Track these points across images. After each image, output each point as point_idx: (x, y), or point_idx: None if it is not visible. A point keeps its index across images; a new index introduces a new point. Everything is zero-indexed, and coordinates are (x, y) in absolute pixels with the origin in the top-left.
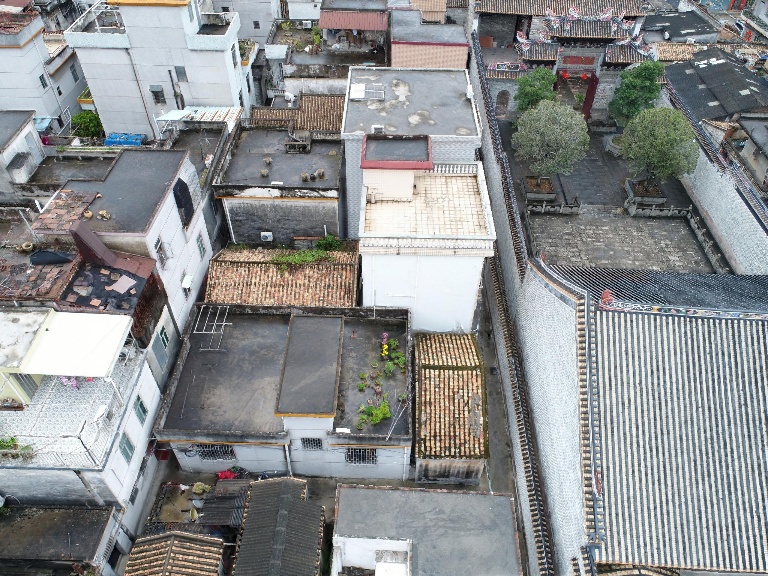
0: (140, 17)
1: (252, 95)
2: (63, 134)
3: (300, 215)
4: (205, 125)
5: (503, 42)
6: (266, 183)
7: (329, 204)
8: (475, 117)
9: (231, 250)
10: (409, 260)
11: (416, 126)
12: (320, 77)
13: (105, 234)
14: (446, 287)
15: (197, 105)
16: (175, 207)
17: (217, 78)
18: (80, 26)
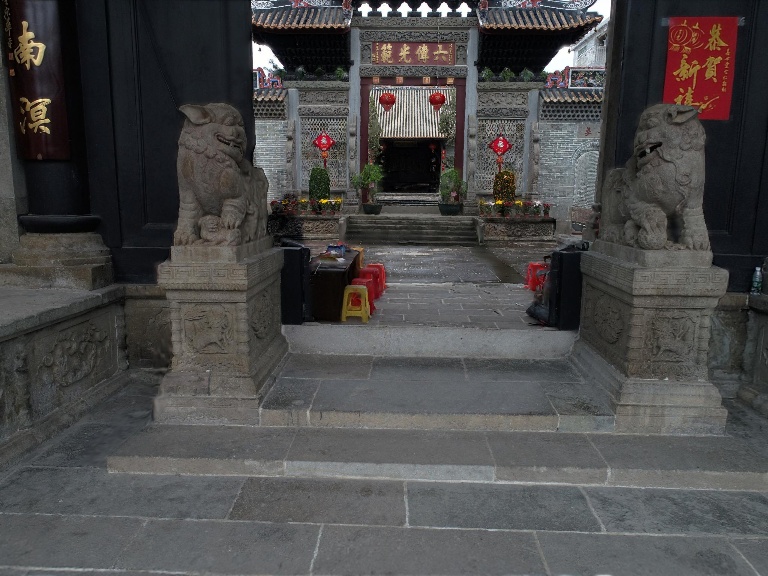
0: None
1: None
2: None
3: None
4: None
5: None
6: None
7: None
8: None
9: None
10: None
11: None
12: None
13: None
14: None
15: None
16: None
17: None
18: None
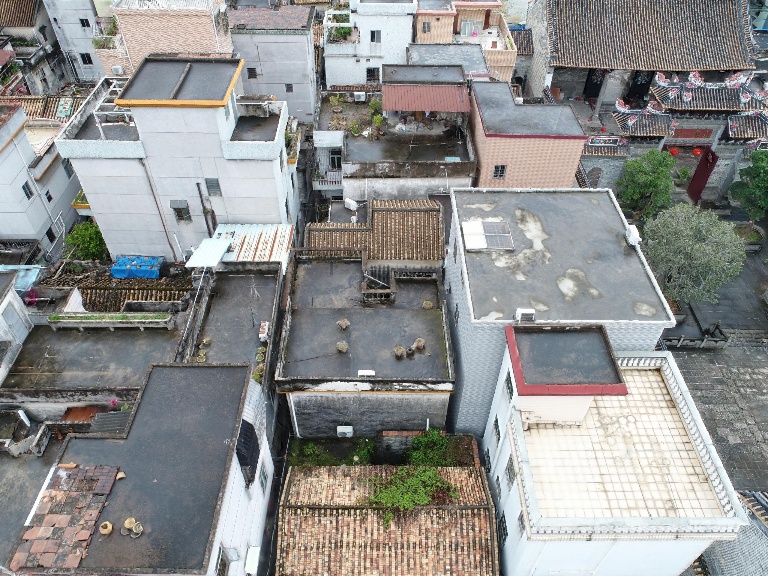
0: (160, 120)
1: (296, 191)
2: (54, 250)
3: (394, 407)
4: (251, 266)
5: (571, 93)
6: (346, 364)
7: (437, 396)
8: (654, 282)
9: (303, 471)
10: (600, 542)
11: (574, 301)
12: (389, 176)
13: (136, 574)
14: (643, 563)
15: (233, 222)
16: (237, 468)
17: (261, 191)
18: (76, 125)
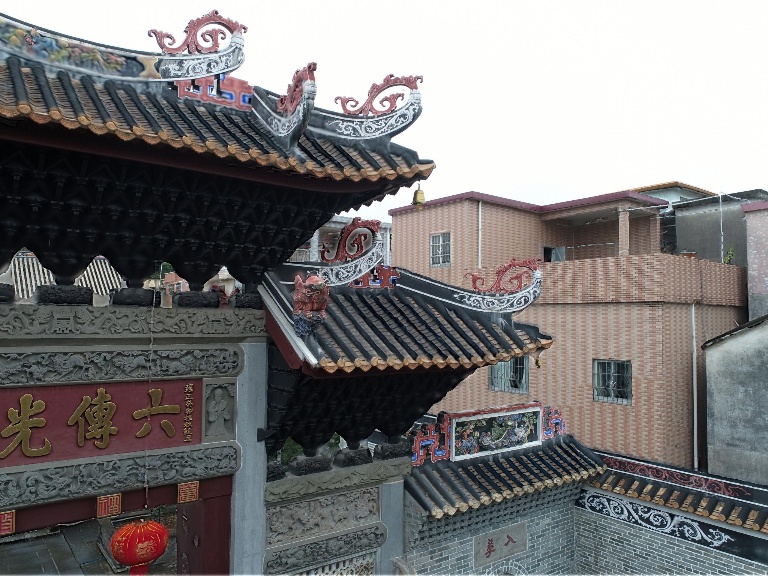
0: None
1: None
2: None
3: None
4: None
5: None
6: None
7: None
8: None
9: None
10: None
11: None
12: None
13: None
14: None
15: None
16: None
17: None
18: None
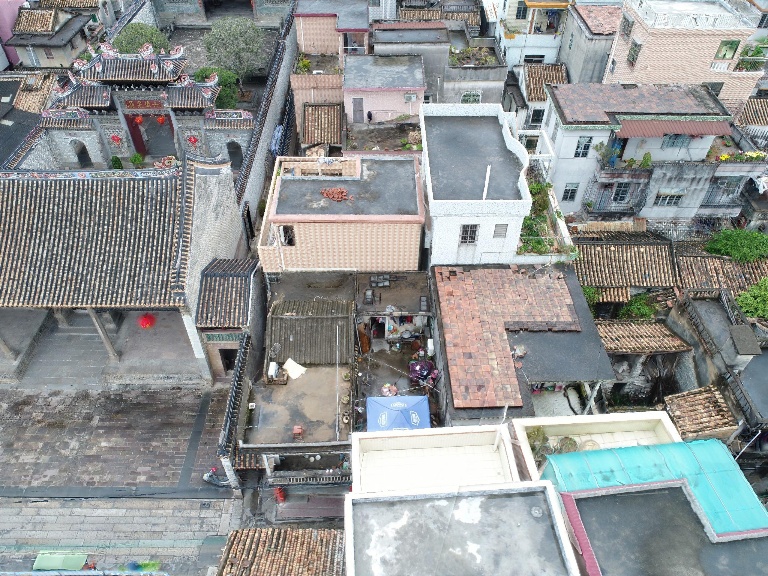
0: None
1: None
2: None
3: None
4: None
5: None
6: None
7: None
8: None
9: None
10: None
11: None
12: None
13: None
14: None
15: None
16: None
17: None
18: None
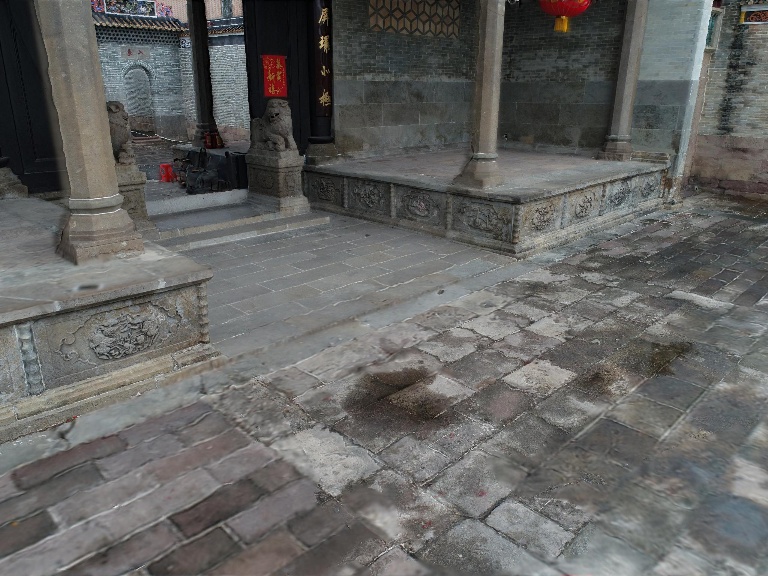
0: None
1: None
2: None
3: None
4: None
5: None
6: None
7: None
8: None
9: None
10: None
11: None
12: None
13: None
14: None
15: None
16: None
17: None
18: None
